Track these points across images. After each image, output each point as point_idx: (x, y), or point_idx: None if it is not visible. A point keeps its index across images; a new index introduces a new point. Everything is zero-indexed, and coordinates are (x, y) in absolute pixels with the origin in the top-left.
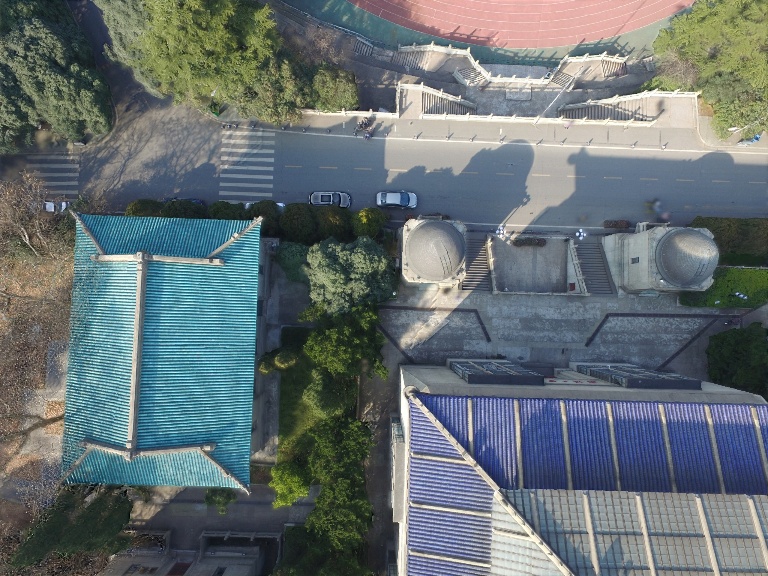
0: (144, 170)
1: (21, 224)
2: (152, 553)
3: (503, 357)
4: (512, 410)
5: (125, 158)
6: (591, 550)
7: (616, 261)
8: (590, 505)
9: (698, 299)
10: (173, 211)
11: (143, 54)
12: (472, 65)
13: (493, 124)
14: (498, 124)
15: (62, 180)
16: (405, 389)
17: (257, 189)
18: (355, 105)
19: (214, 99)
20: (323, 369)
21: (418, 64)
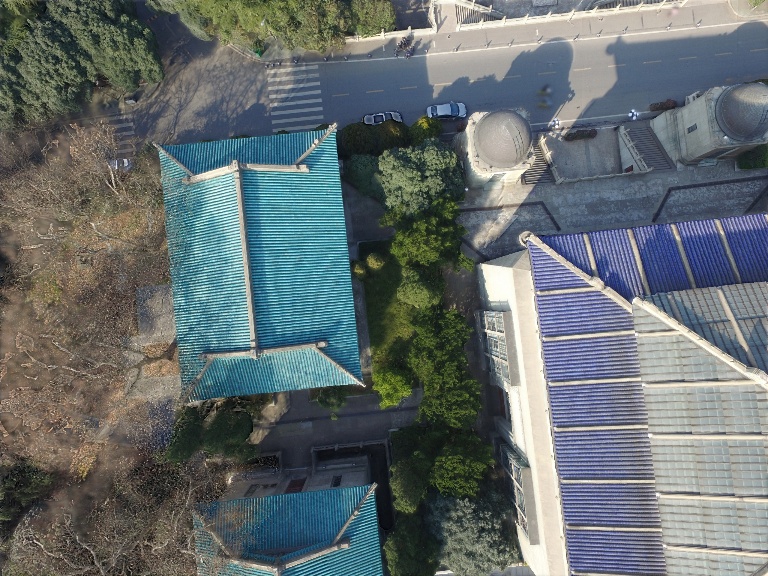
0: (197, 119)
1: (95, 176)
2: (266, 474)
3: None
4: (627, 238)
5: (176, 110)
6: (736, 333)
7: (670, 137)
8: (726, 298)
9: (756, 160)
10: None
11: None
12: None
13: (529, 26)
14: (534, 26)
15: None
16: (521, 235)
17: (309, 122)
18: (393, 25)
19: (259, 35)
20: (412, 266)
21: None
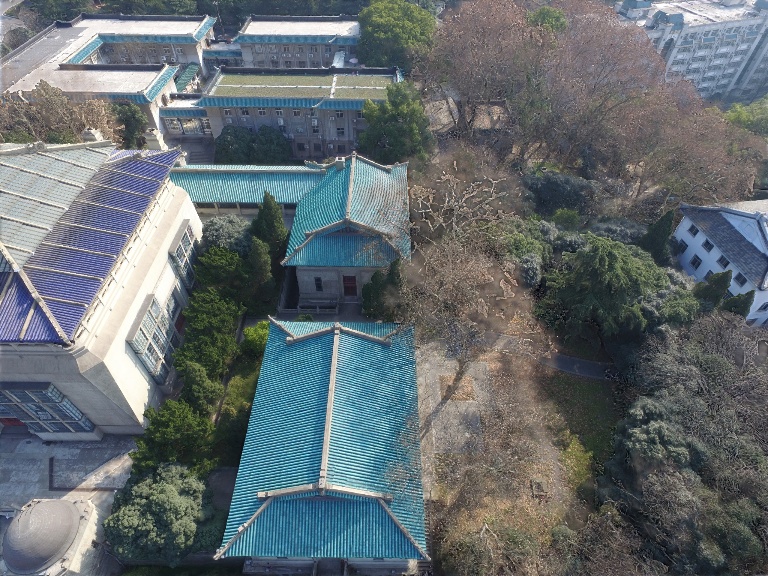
0: None
1: None
2: None
3: (45, 443)
4: None
5: None
6: None
7: None
8: None
9: None
10: None
11: None
12: None
13: None
14: None
15: None
16: (73, 347)
17: None
18: None
19: None
20: (199, 411)
21: None
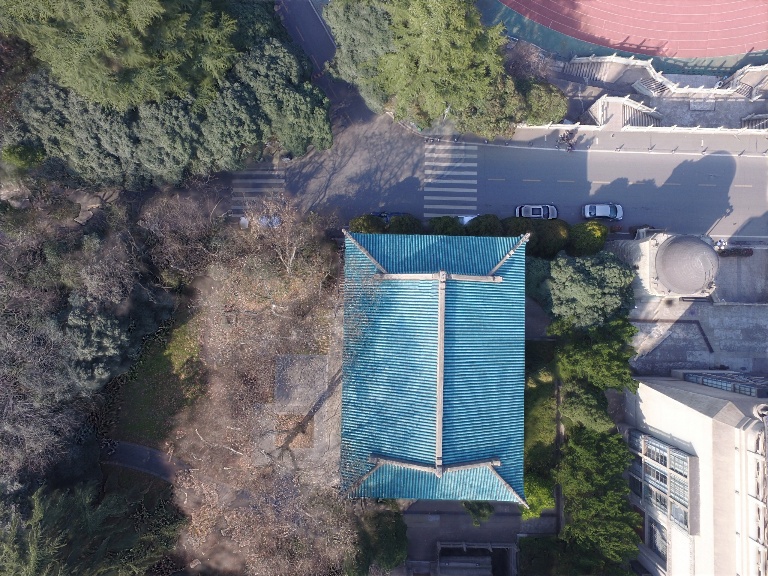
0: (349, 184)
1: None
2: None
3: (726, 368)
4: None
5: (330, 173)
6: None
7: None
8: None
9: None
10: (405, 226)
11: (393, 73)
12: (651, 76)
13: (695, 136)
14: (699, 136)
15: (268, 195)
16: (758, 407)
17: (461, 202)
18: (561, 118)
19: None
20: (580, 383)
21: (595, 75)
